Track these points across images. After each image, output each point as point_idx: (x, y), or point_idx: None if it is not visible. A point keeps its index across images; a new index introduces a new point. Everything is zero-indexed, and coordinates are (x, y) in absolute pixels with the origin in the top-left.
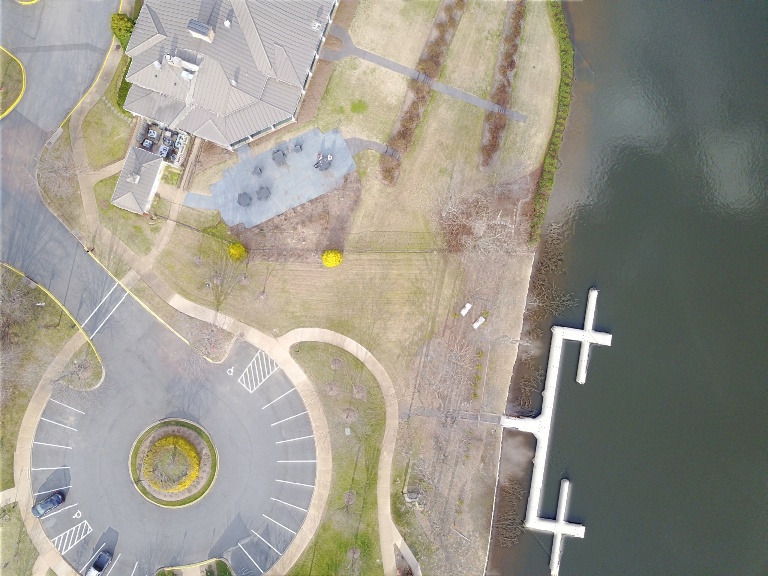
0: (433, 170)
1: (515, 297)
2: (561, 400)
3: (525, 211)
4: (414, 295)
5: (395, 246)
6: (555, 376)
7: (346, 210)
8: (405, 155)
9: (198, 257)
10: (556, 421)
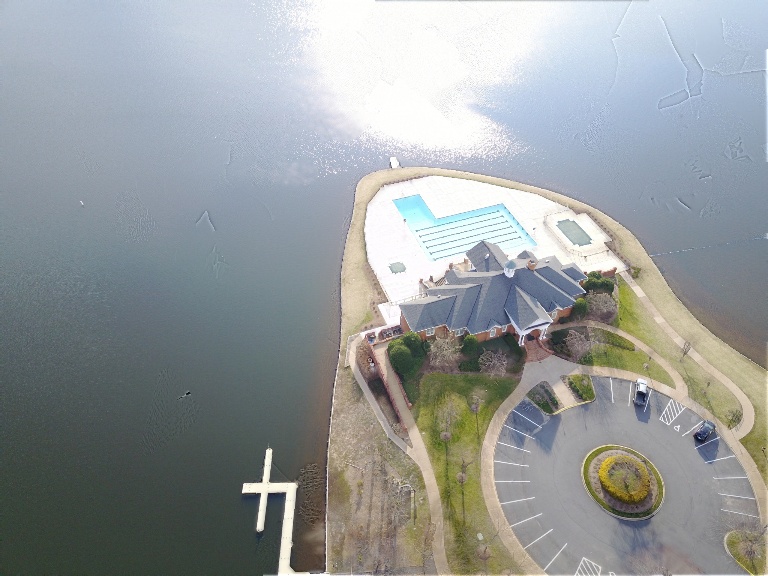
0: None
1: None
2: None
3: None
4: None
5: None
6: None
7: None
8: None
9: None
10: None
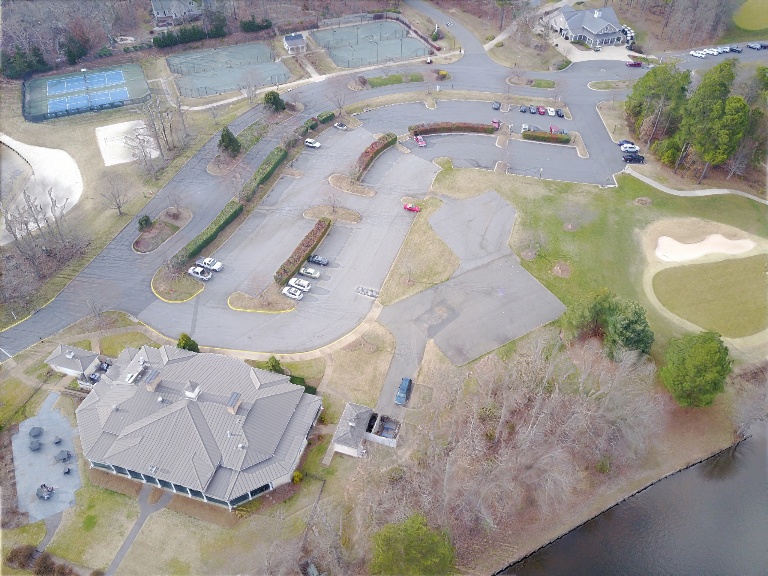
0: None
1: None
2: None
3: None
4: None
5: None
6: None
7: None
8: (32, 574)
9: (5, 404)
10: None
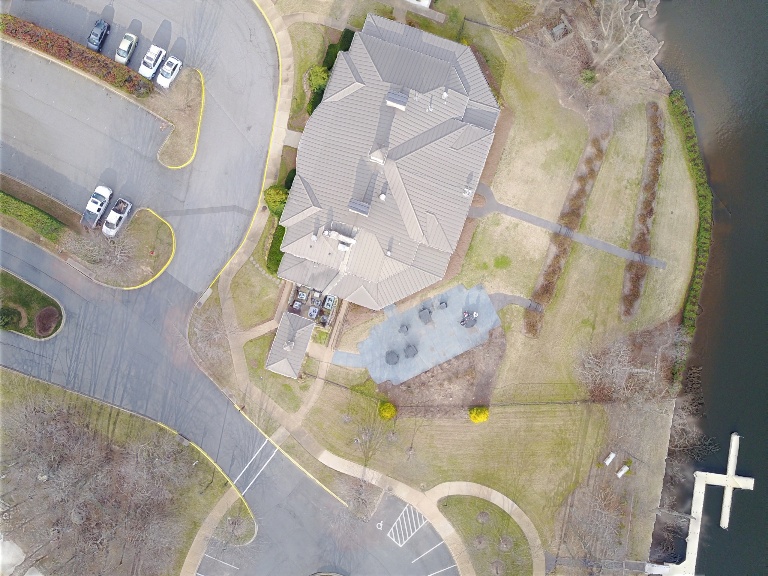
0: (575, 321)
1: (657, 443)
2: (703, 544)
3: (665, 357)
4: (558, 446)
5: (539, 398)
6: (699, 522)
7: (491, 365)
8: (547, 307)
9: (346, 414)
10: (700, 566)
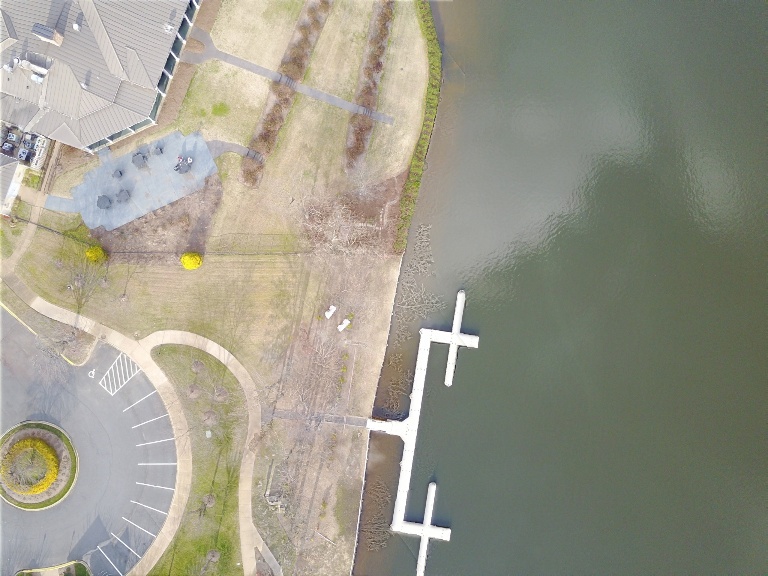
0: (297, 172)
1: (382, 299)
2: (431, 403)
3: (393, 213)
4: (277, 298)
5: (258, 248)
6: (423, 379)
7: (207, 213)
8: (268, 157)
9: (59, 260)
10: (424, 424)
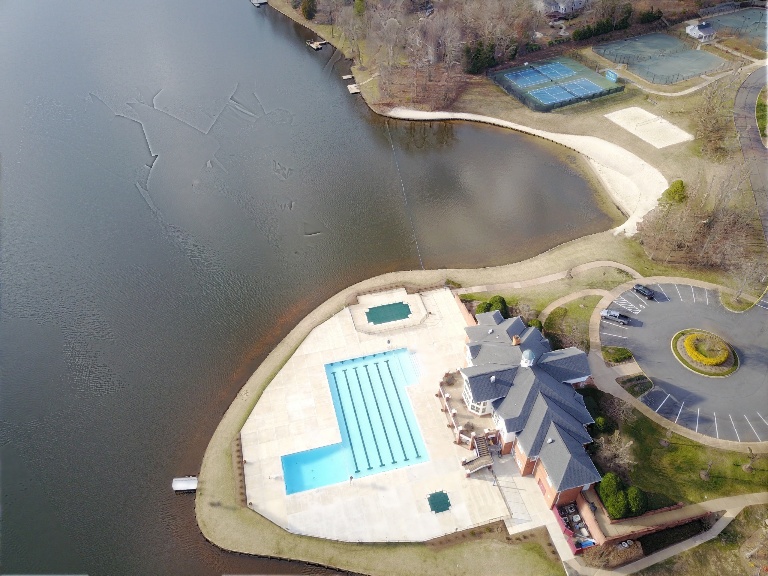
0: None
1: None
2: None
3: None
4: None
5: None
6: None
7: None
8: None
9: None
10: None
